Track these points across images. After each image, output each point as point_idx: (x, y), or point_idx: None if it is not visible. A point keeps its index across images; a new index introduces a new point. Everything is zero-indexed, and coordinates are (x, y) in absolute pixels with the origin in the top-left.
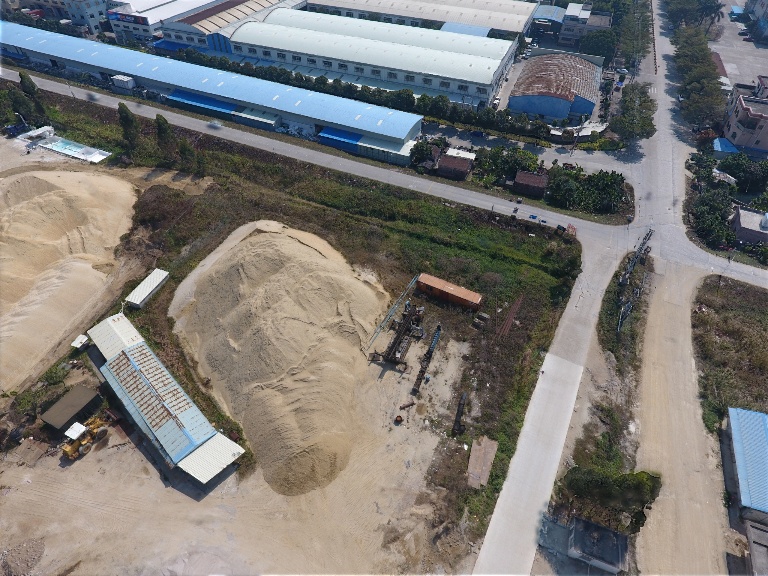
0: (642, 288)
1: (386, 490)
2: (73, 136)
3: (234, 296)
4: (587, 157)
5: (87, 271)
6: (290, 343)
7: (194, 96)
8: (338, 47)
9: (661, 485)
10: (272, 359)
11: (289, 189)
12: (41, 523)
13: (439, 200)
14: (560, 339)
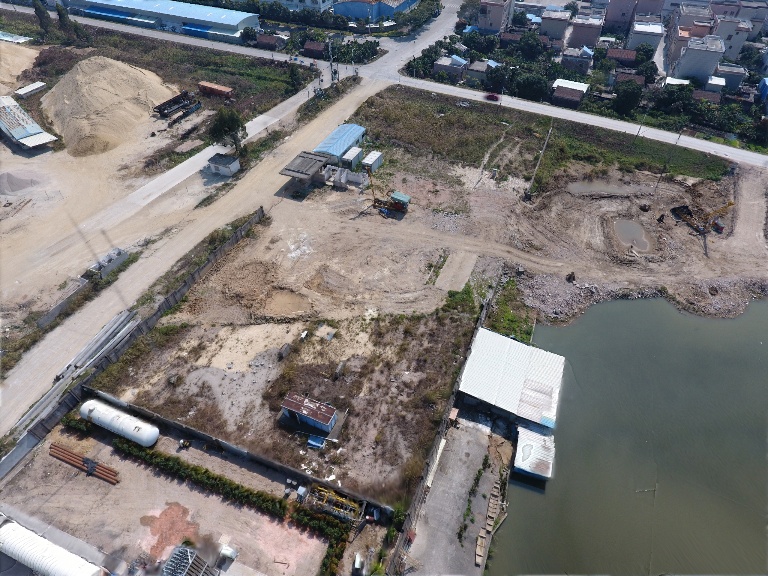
0: None
1: (131, 155)
2: (8, 29)
3: (73, 82)
4: (373, 40)
5: None
6: (98, 99)
7: (103, 9)
8: None
9: (239, 117)
10: (84, 104)
11: (147, 54)
12: None
13: (243, 55)
14: (274, 110)
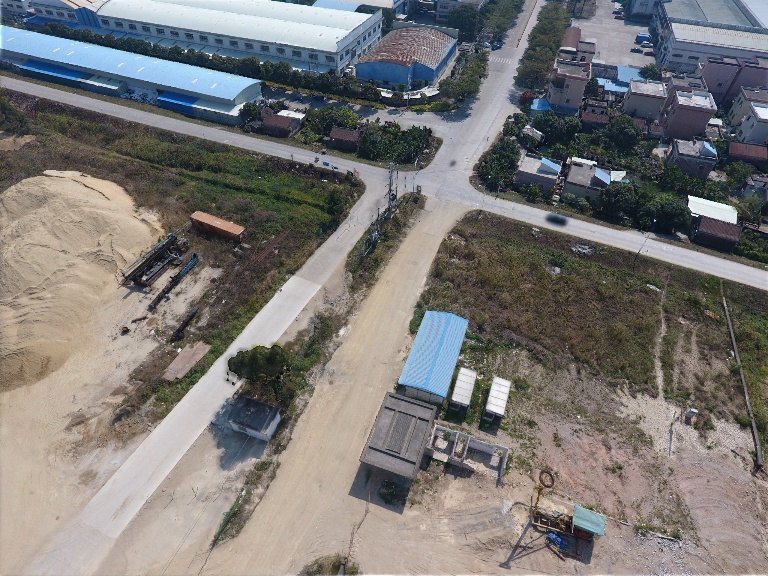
0: None
1: (88, 385)
2: None
3: None
4: (415, 117)
5: None
6: (31, 266)
7: (45, 65)
8: (199, 20)
9: (284, 354)
10: (8, 279)
11: (110, 146)
12: None
13: (248, 152)
14: (311, 264)
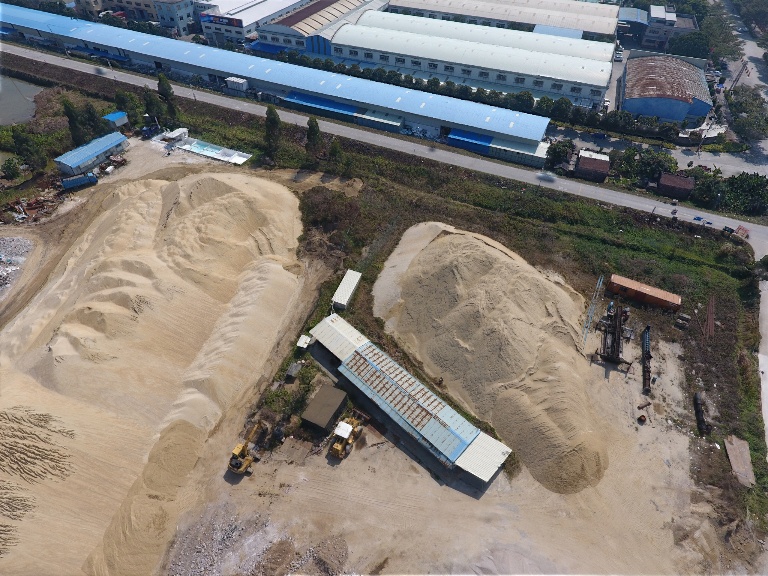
0: None
1: (657, 489)
2: (209, 138)
3: (451, 297)
4: (716, 159)
5: (281, 272)
6: (523, 343)
7: (311, 98)
8: (443, 49)
9: None
10: (512, 359)
11: (438, 191)
12: (334, 521)
13: (594, 202)
14: (766, 340)
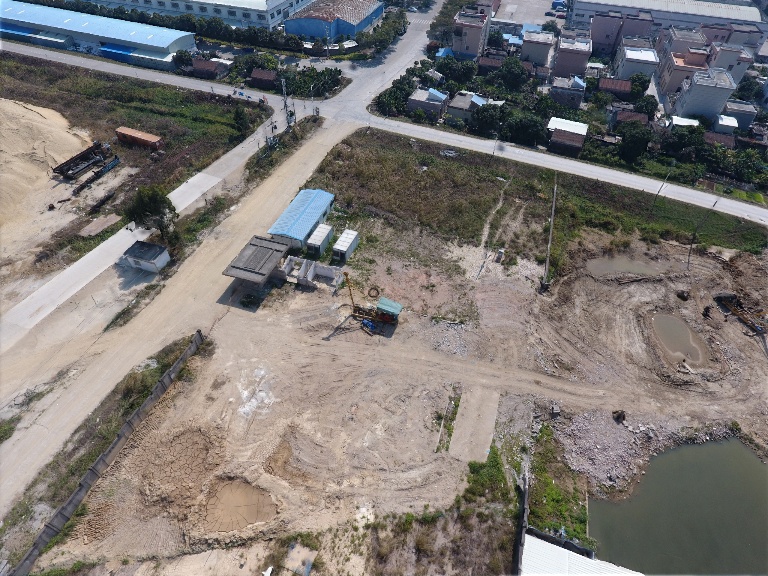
0: (266, 119)
1: (17, 241)
2: None
3: None
4: (333, 64)
5: None
6: None
7: None
8: None
9: (164, 197)
10: None
11: (53, 85)
12: None
13: (175, 88)
14: (216, 165)
